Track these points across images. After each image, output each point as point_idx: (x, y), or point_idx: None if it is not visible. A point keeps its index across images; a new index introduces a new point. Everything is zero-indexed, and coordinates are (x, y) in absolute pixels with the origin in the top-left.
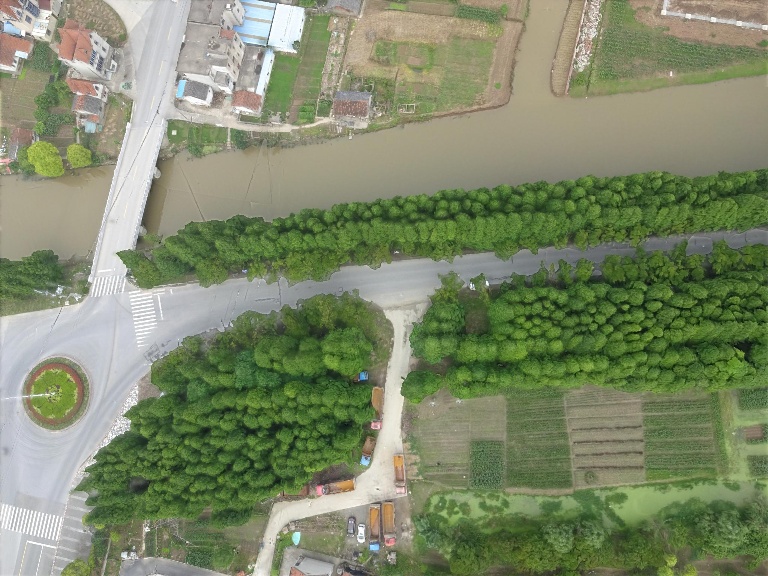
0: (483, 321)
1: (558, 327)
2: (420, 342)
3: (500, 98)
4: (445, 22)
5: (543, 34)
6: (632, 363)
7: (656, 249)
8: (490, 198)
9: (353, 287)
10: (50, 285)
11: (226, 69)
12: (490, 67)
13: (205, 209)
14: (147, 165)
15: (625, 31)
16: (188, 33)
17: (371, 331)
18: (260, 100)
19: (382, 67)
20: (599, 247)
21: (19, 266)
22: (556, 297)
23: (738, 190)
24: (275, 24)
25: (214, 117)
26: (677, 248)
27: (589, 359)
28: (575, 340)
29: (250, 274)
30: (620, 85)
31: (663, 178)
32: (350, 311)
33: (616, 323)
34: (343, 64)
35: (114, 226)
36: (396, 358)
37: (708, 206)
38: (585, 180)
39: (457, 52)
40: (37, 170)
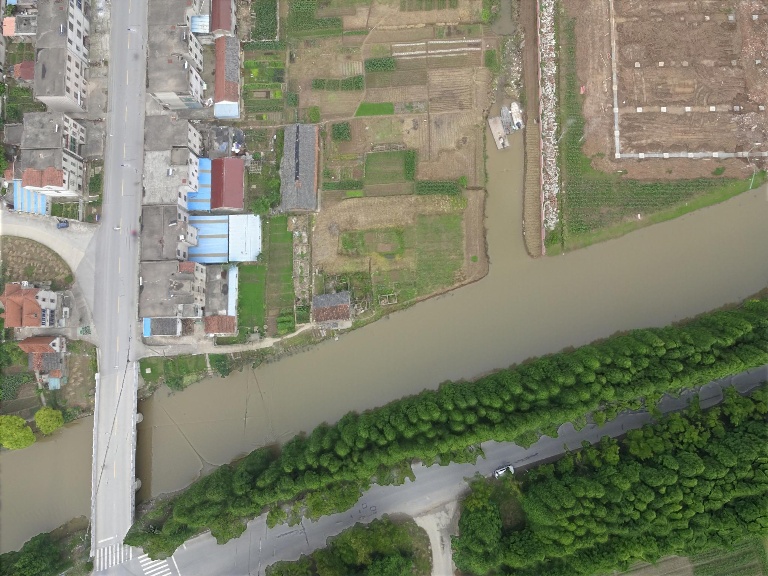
0: (517, 510)
1: (602, 525)
2: (465, 560)
3: (479, 271)
4: (407, 202)
5: (506, 196)
6: (682, 545)
7: (671, 408)
8: (504, 402)
9: (376, 501)
10: (49, 573)
11: (193, 303)
12: (462, 240)
13: (196, 436)
14: (127, 415)
15: (586, 182)
16: (144, 274)
17: (405, 542)
18: (234, 321)
19: (353, 260)
20: (616, 416)
21: (14, 575)
22: (594, 496)
23: (737, 340)
24: (232, 237)
25: (188, 345)
26: (692, 407)
27: (637, 544)
28: (621, 532)
29: (270, 523)
30: (593, 236)
31: (666, 346)
32: (385, 543)
33: (657, 507)
34: (312, 263)
35: (105, 489)
36: (438, 567)
37: (716, 368)
38: (592, 364)
39: (426, 231)
40: (5, 446)
